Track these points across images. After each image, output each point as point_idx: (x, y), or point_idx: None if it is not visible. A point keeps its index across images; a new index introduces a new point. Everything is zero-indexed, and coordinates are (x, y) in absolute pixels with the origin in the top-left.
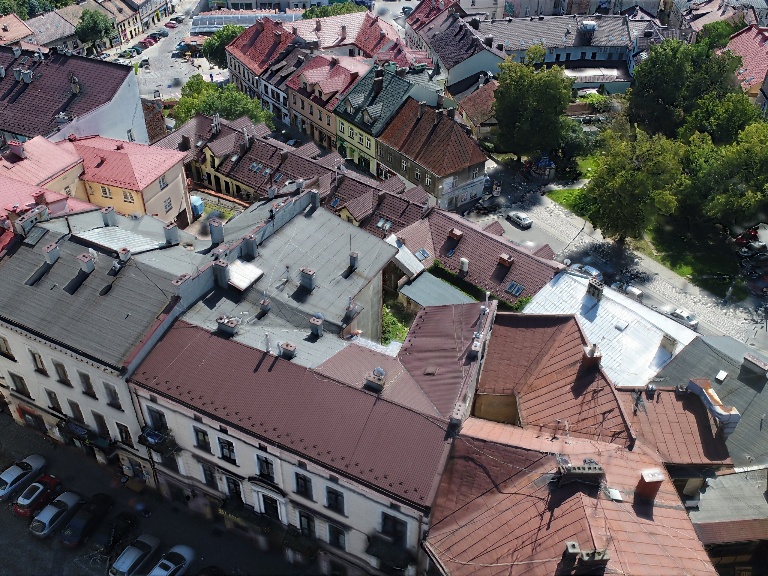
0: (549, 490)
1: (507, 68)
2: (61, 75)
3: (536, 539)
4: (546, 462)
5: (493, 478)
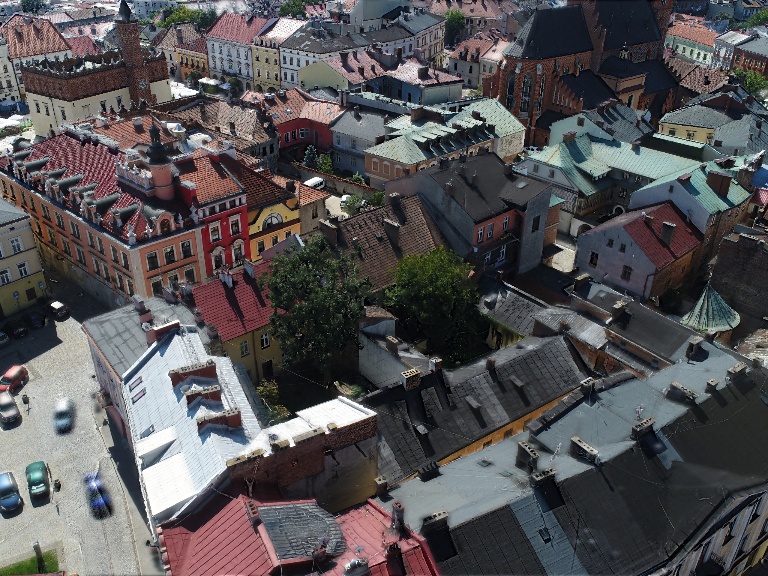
0: (438, 2)
1: None
2: (222, 4)
3: (441, 5)
4: (434, 1)
5: (431, 5)
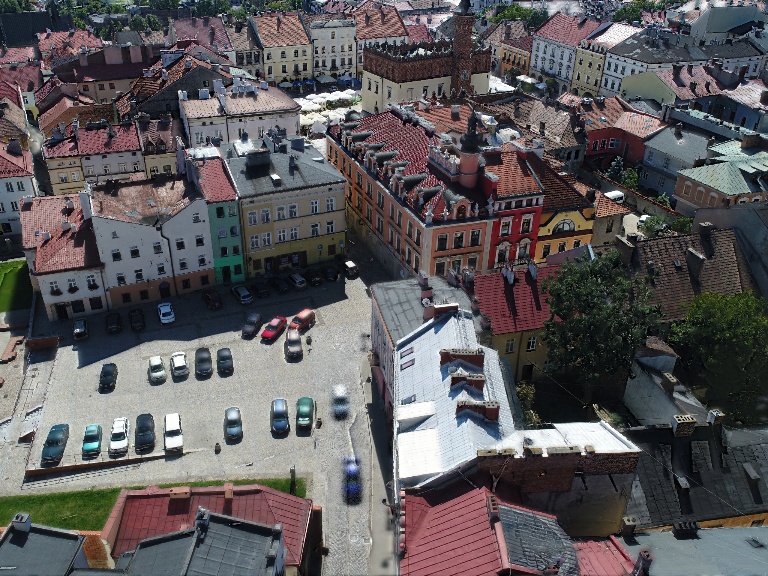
0: None
1: (637, 3)
2: (555, 5)
3: None
4: None
5: None
